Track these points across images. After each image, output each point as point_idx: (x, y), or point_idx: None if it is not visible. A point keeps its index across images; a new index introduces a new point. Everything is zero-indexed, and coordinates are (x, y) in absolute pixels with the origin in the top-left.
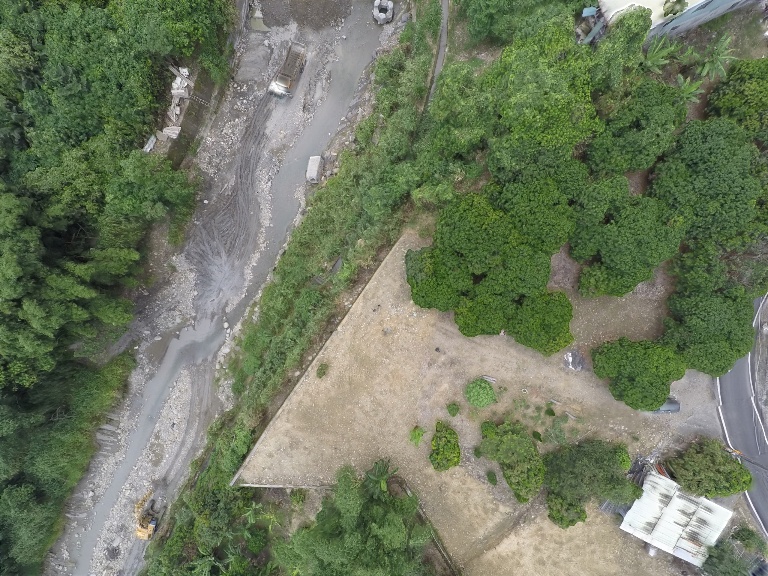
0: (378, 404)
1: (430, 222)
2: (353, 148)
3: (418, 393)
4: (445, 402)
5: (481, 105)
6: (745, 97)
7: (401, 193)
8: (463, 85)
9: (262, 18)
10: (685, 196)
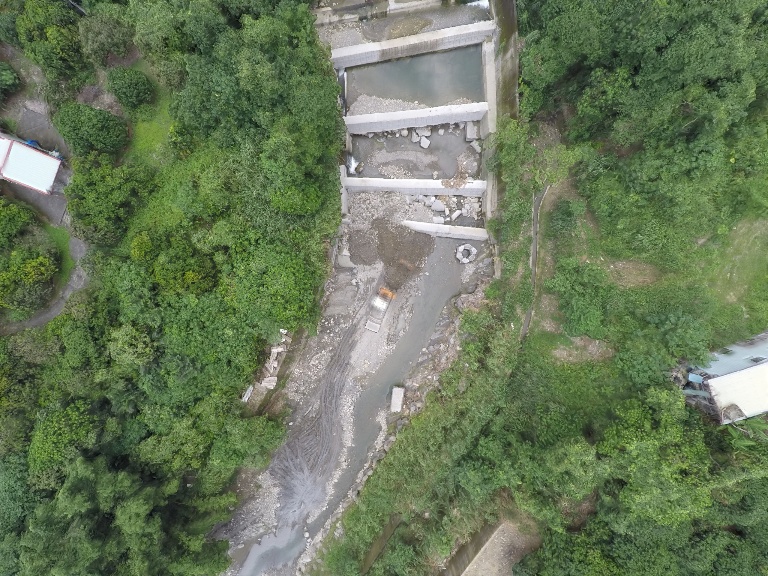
0: None
1: (532, 525)
2: (436, 385)
3: None
4: None
5: (599, 473)
6: None
7: (501, 486)
8: None
9: (349, 256)
10: None
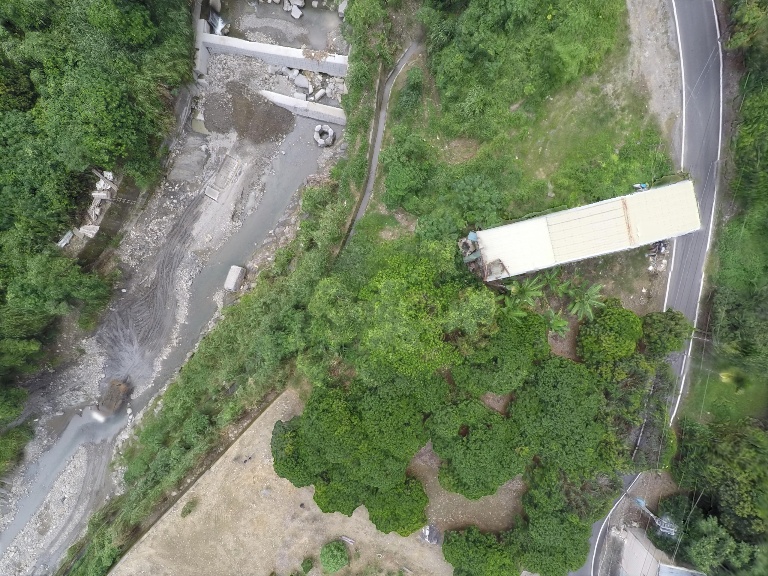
0: (240, 545)
1: (309, 389)
2: (273, 267)
3: (279, 542)
4: (303, 554)
5: (352, 316)
6: (603, 347)
7: (290, 350)
8: (336, 295)
9: (204, 121)
10: (533, 430)
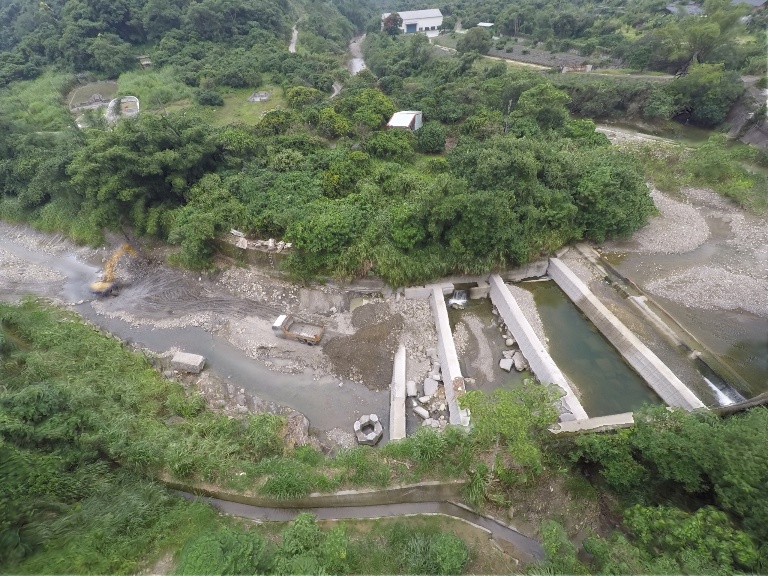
0: None
1: None
2: None
3: None
4: None
5: None
6: None
7: None
8: None
9: None
10: None
